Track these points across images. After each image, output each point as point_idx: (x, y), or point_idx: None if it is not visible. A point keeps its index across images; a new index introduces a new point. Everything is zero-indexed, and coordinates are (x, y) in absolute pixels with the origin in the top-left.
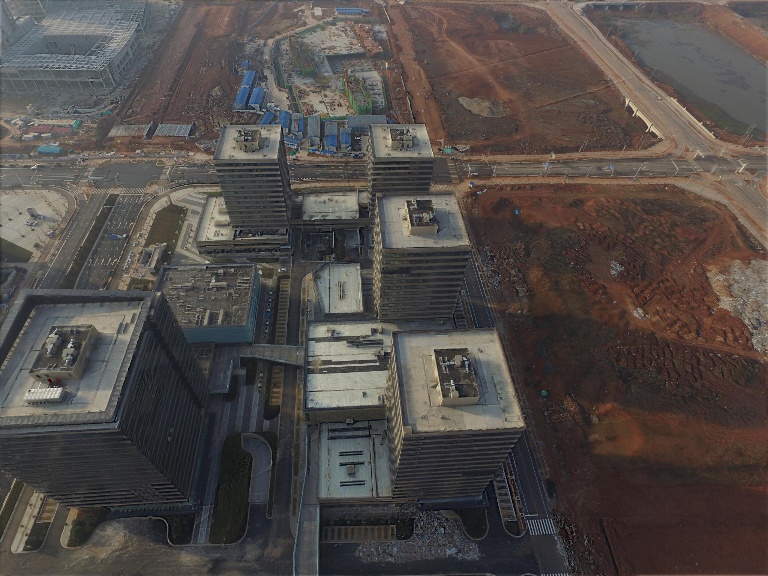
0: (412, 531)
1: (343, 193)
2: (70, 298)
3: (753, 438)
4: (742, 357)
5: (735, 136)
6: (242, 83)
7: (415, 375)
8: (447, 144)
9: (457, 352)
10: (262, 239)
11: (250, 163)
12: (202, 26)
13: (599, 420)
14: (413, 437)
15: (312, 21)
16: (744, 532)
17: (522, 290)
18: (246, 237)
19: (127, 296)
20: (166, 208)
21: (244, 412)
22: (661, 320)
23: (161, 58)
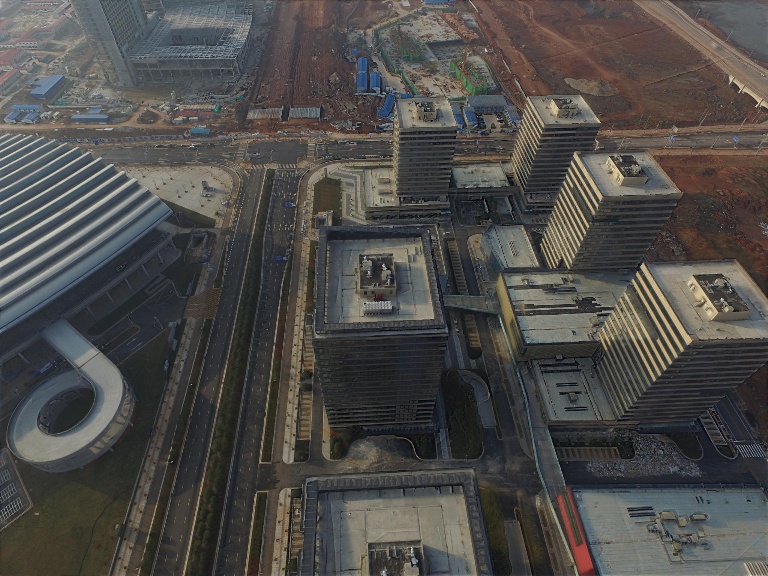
0: (634, 452)
1: (487, 164)
2: (359, 234)
3: None
4: None
5: None
6: (358, 69)
7: (677, 297)
8: None
9: (714, 277)
10: (426, 205)
11: (432, 131)
12: (301, 19)
13: None
14: (696, 345)
15: (403, 11)
16: None
17: (678, 249)
18: (410, 203)
19: (407, 232)
20: (324, 180)
21: (450, 353)
22: None
23: (272, 49)
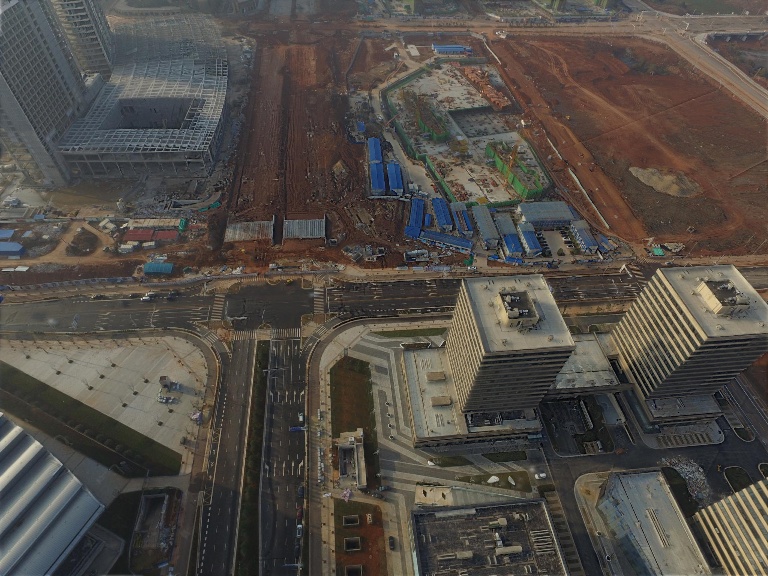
0: None
1: (577, 337)
2: None
3: None
4: None
5: None
6: (370, 157)
7: None
8: (652, 241)
9: None
10: (508, 430)
11: (535, 353)
12: (288, 73)
13: None
14: None
15: (412, 63)
16: None
17: None
18: (482, 425)
19: None
20: (345, 367)
21: None
22: None
23: (254, 119)
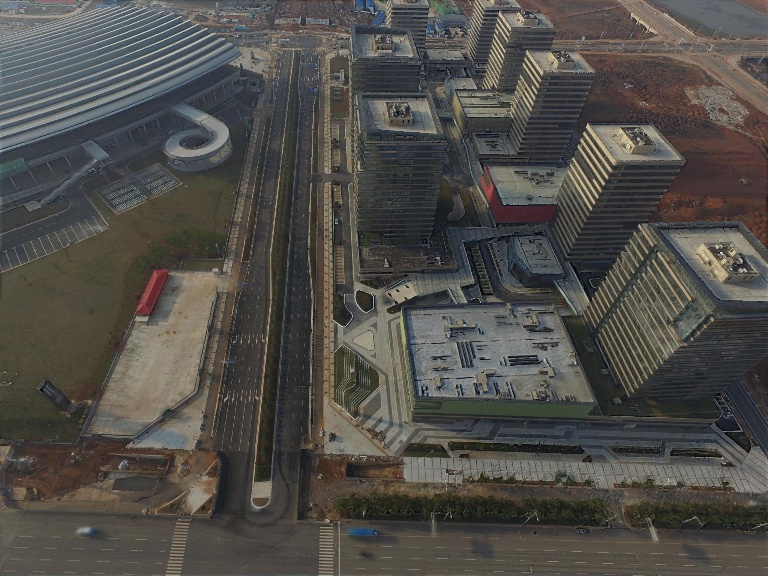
0: None
1: (450, 49)
2: (372, 30)
3: (706, 144)
4: (703, 120)
5: (709, 36)
6: None
7: (542, 61)
8: None
9: None
10: None
11: (413, 8)
12: None
13: None
14: (546, 76)
15: None
16: (699, 180)
17: None
18: None
19: (399, 30)
20: (337, 56)
21: None
22: (656, 106)
23: None
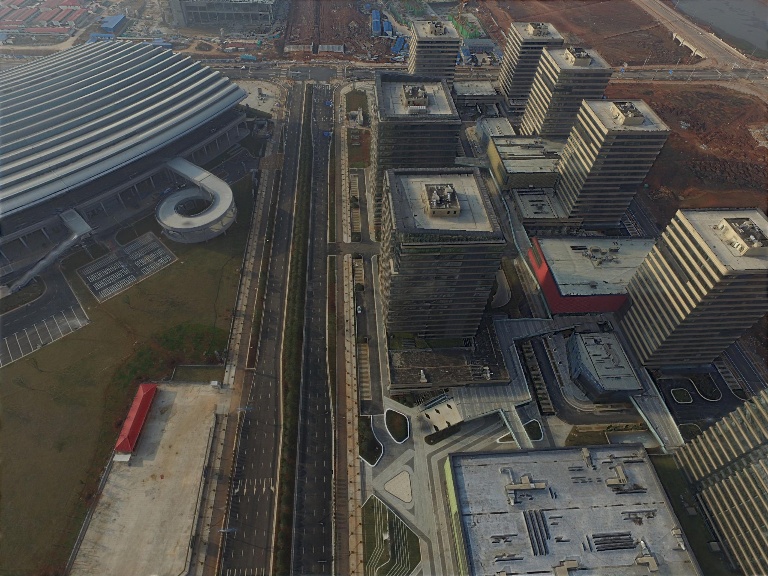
0: None
1: (480, 82)
2: (401, 78)
3: None
4: None
5: (762, 59)
6: (373, 18)
7: (603, 115)
8: None
9: None
10: None
11: (441, 41)
12: None
13: (684, 198)
14: (611, 135)
15: None
16: None
17: None
18: None
19: (432, 77)
20: (354, 90)
21: None
22: (720, 150)
23: (297, 3)
